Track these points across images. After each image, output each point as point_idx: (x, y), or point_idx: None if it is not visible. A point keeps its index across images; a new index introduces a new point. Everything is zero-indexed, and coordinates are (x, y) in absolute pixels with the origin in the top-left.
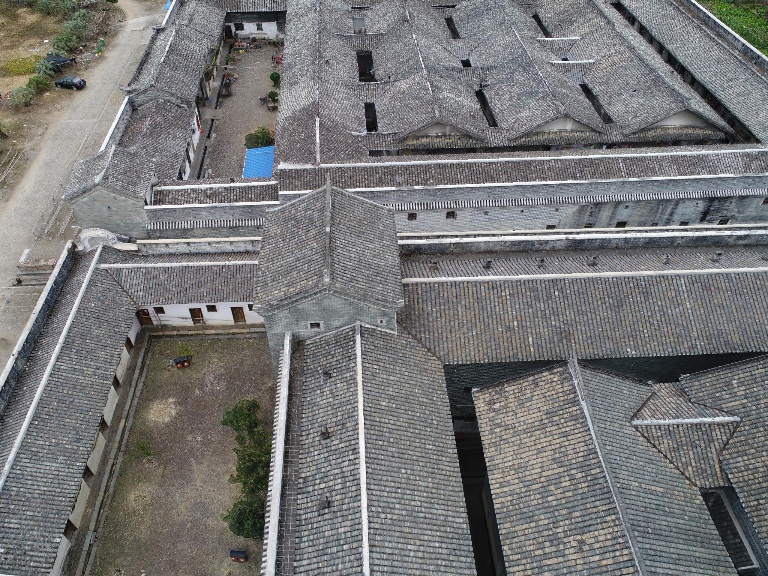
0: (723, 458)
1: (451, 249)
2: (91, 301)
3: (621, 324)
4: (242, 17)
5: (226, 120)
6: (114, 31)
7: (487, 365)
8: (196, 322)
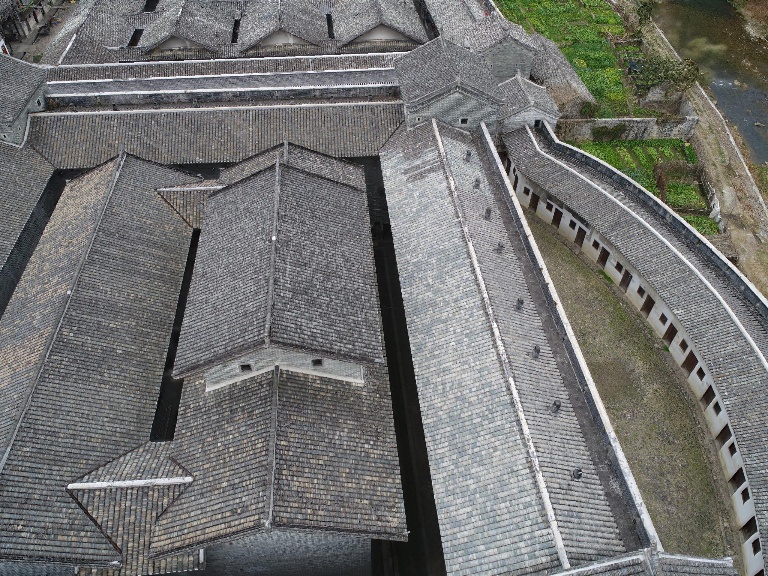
0: None
1: (98, 102)
2: None
3: (196, 142)
4: None
5: (37, 53)
6: None
7: None
8: None
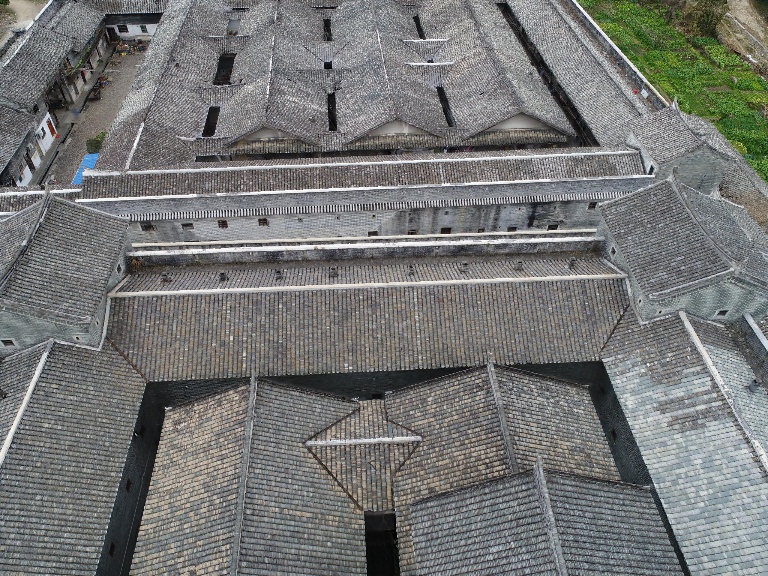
0: (395, 480)
1: (196, 260)
2: None
3: (343, 338)
4: (125, 19)
5: (86, 124)
6: (0, 33)
7: (217, 381)
8: None
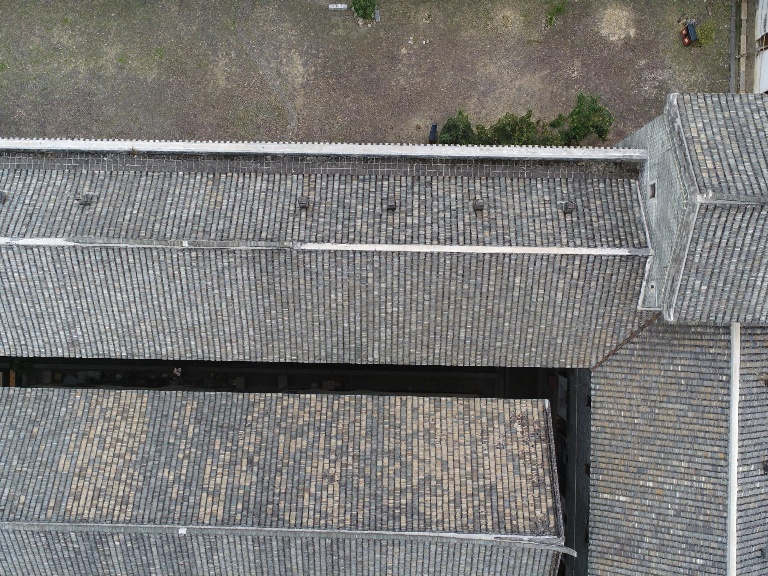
0: None
1: None
2: None
3: None
4: None
5: None
6: None
7: None
8: (761, 42)
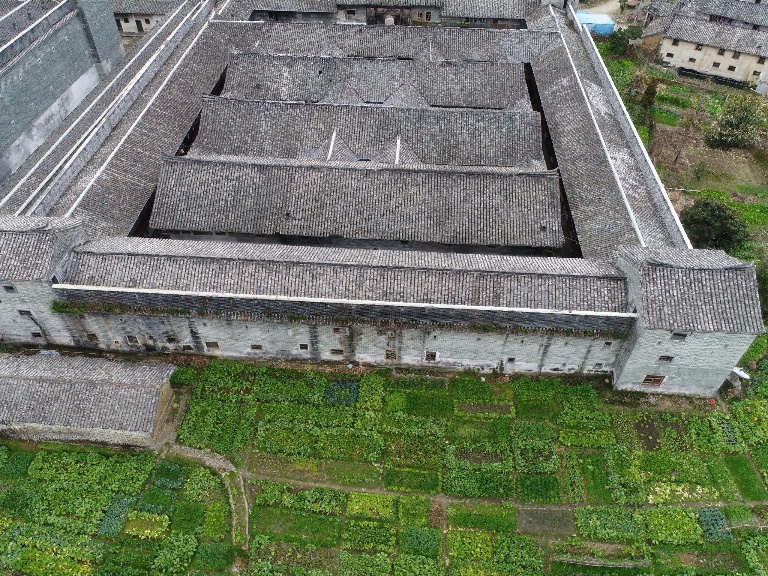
0: None
1: None
2: None
3: None
4: None
5: None
6: None
7: None
8: None
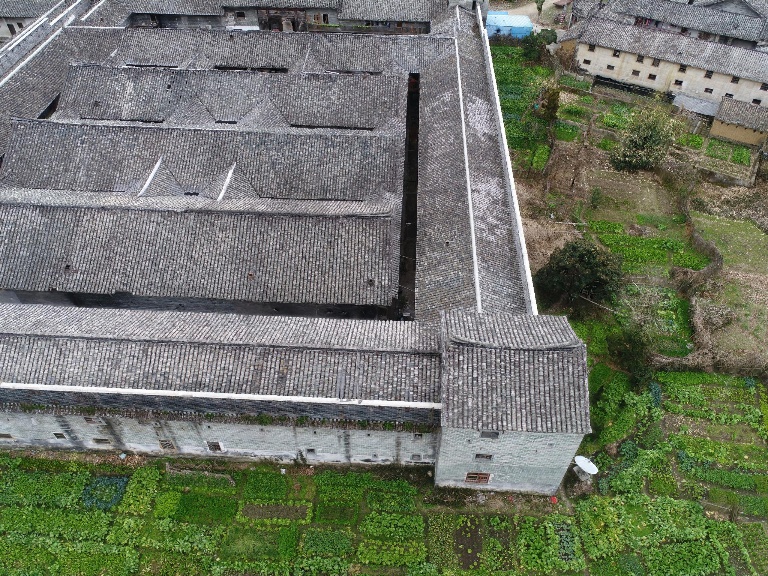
0: None
1: None
2: (40, 0)
3: None
4: None
5: None
6: None
7: None
8: None
